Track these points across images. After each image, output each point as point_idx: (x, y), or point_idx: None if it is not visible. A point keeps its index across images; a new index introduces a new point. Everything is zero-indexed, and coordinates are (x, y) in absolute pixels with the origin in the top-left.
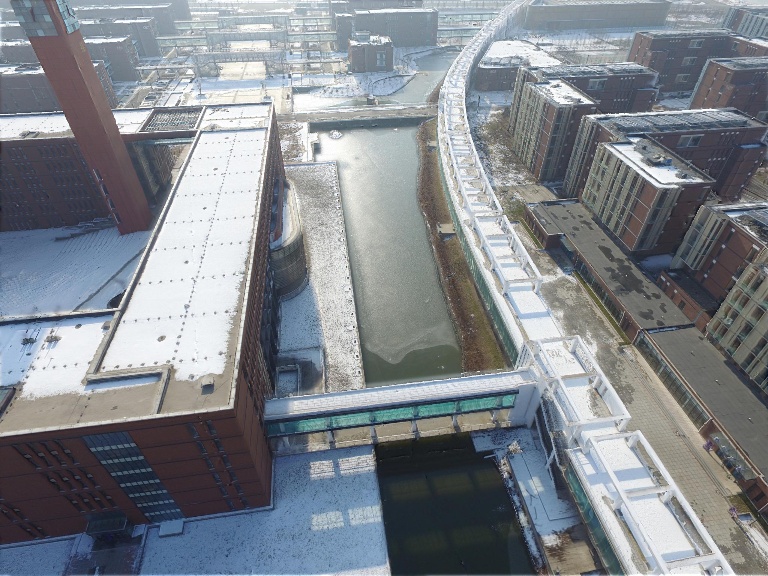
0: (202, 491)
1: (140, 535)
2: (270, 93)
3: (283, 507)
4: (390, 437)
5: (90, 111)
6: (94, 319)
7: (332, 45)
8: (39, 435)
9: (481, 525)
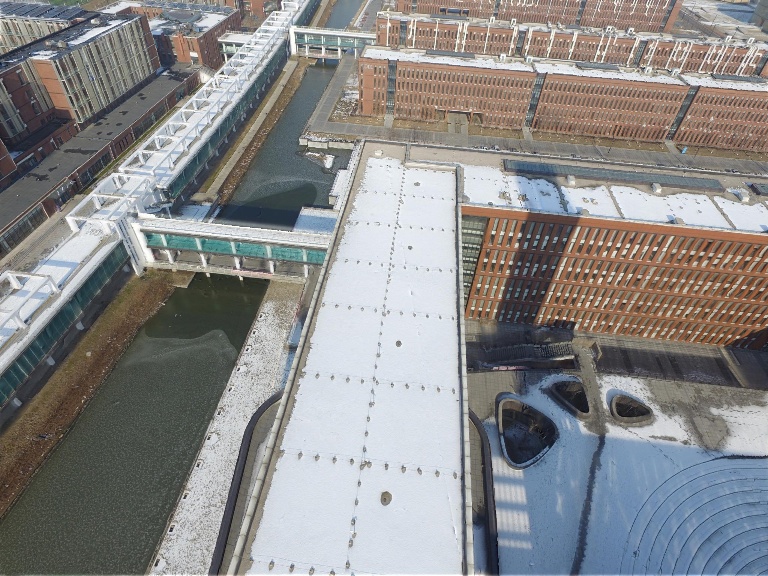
0: None
1: None
2: None
3: None
4: None
5: None
6: None
7: None
8: None
9: (237, 224)
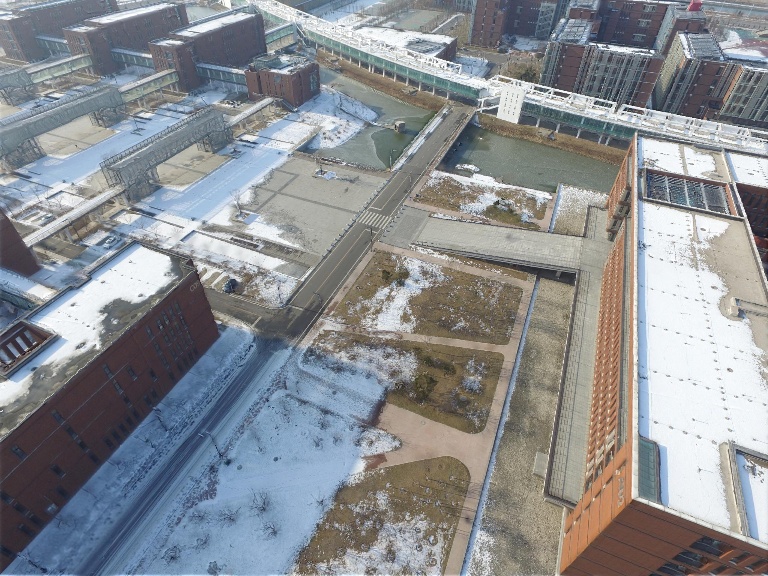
0: None
1: None
2: (300, 168)
3: None
4: None
5: None
6: None
7: None
8: None
9: None
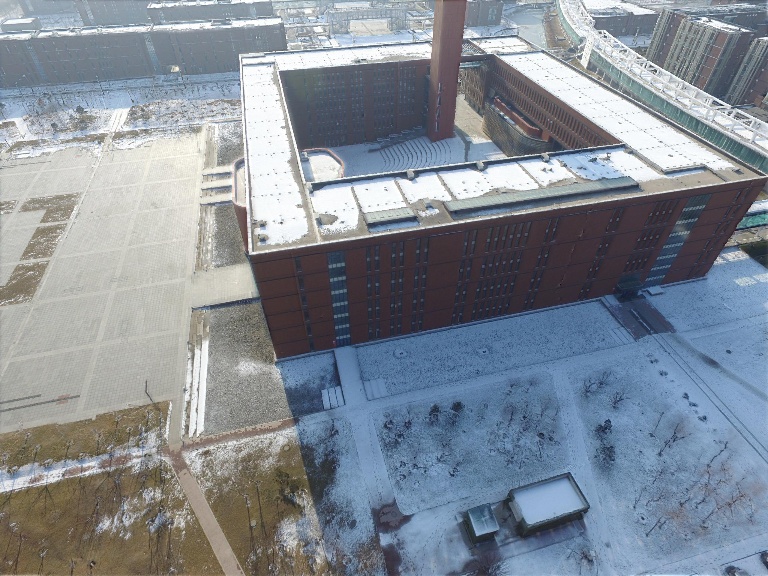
0: (691, 257)
1: (641, 294)
2: None
3: (711, 278)
4: (749, 239)
5: (459, 32)
6: (613, 150)
7: (422, 6)
8: (675, 194)
9: None
